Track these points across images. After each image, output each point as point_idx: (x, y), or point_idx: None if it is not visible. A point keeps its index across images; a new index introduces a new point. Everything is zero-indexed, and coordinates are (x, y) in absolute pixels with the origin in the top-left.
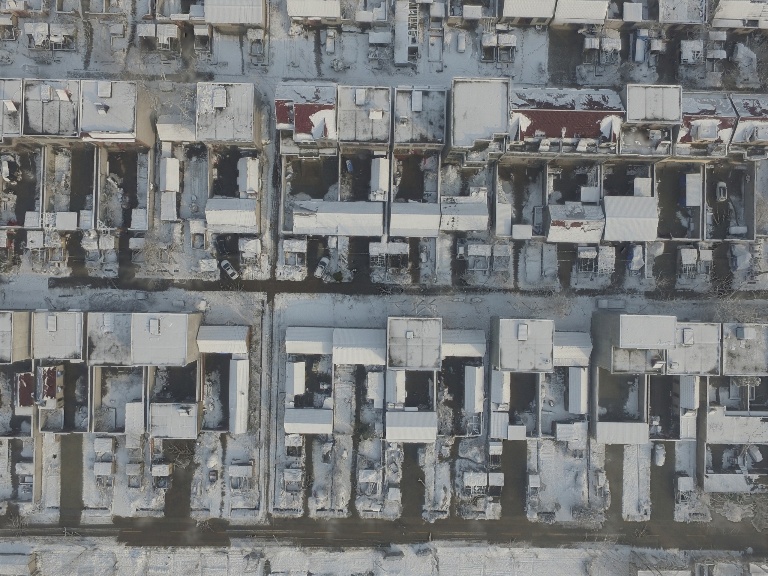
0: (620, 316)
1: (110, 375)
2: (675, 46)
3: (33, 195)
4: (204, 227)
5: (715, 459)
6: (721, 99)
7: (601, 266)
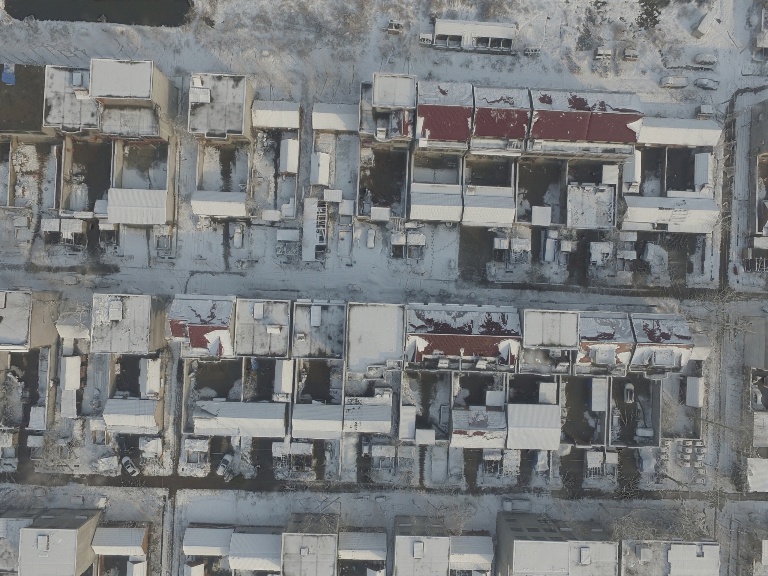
0: (514, 542)
1: None
2: (586, 244)
3: None
4: (104, 425)
5: None
6: (621, 319)
7: (506, 468)
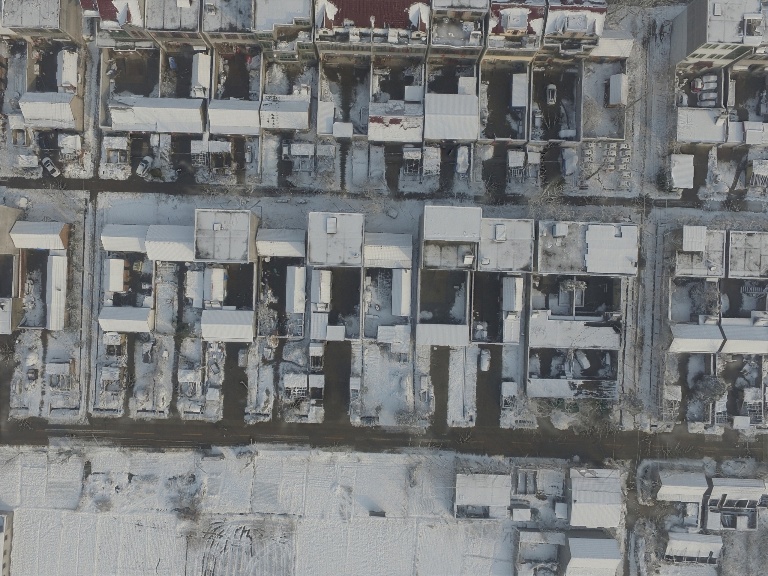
0: (424, 207)
1: None
2: None
3: None
4: (24, 123)
5: (543, 366)
6: None
7: (426, 167)
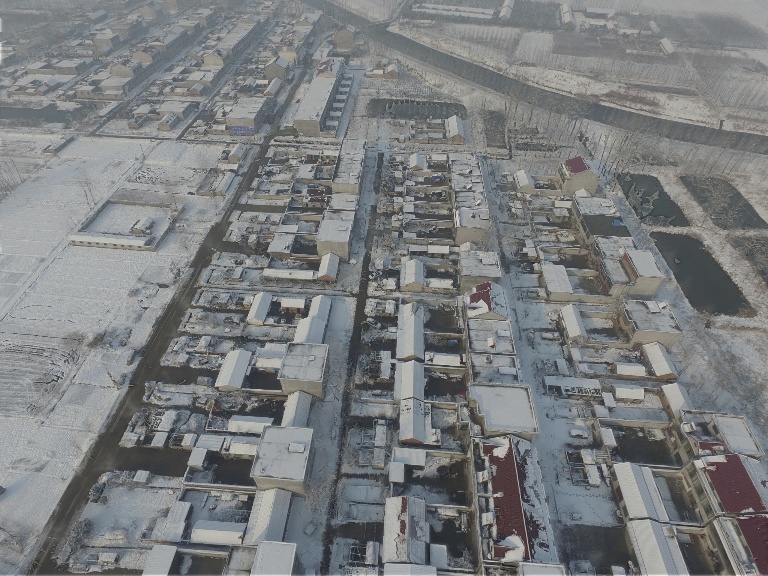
0: None
1: (317, 224)
2: None
3: None
4: None
5: None
6: None
7: (355, 571)
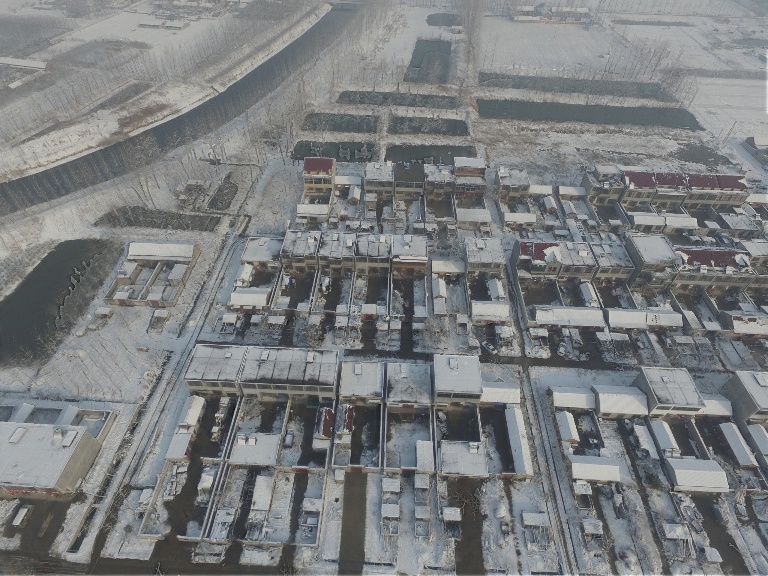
0: None
1: (394, 423)
2: None
3: (338, 300)
4: (467, 319)
5: None
6: None
7: None
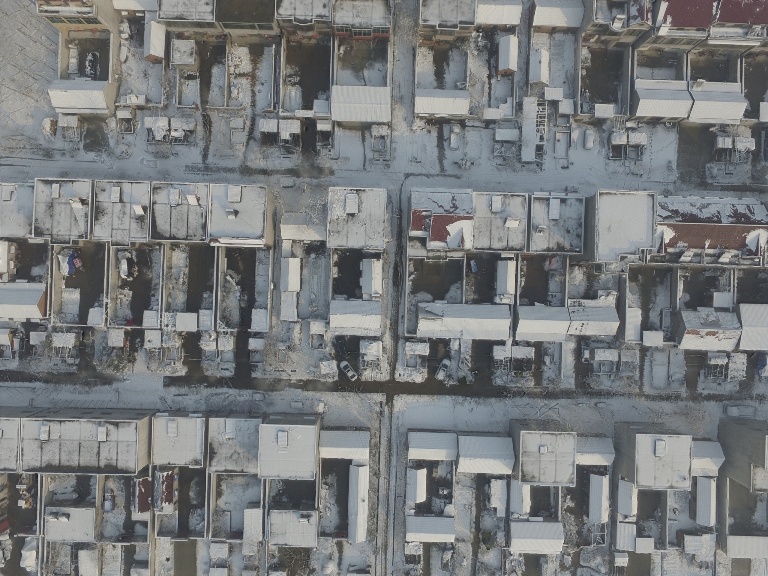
0: (766, 437)
1: (225, 477)
2: None
3: (149, 291)
4: (325, 328)
5: None
6: None
7: (732, 373)
